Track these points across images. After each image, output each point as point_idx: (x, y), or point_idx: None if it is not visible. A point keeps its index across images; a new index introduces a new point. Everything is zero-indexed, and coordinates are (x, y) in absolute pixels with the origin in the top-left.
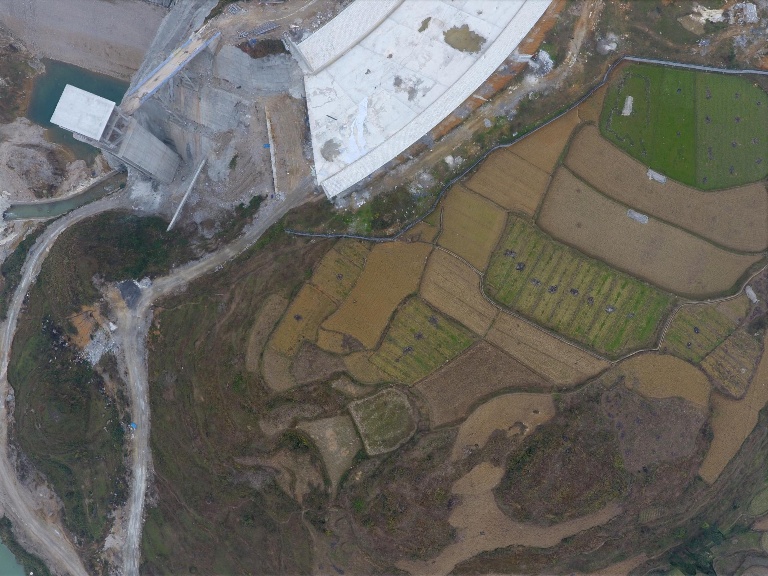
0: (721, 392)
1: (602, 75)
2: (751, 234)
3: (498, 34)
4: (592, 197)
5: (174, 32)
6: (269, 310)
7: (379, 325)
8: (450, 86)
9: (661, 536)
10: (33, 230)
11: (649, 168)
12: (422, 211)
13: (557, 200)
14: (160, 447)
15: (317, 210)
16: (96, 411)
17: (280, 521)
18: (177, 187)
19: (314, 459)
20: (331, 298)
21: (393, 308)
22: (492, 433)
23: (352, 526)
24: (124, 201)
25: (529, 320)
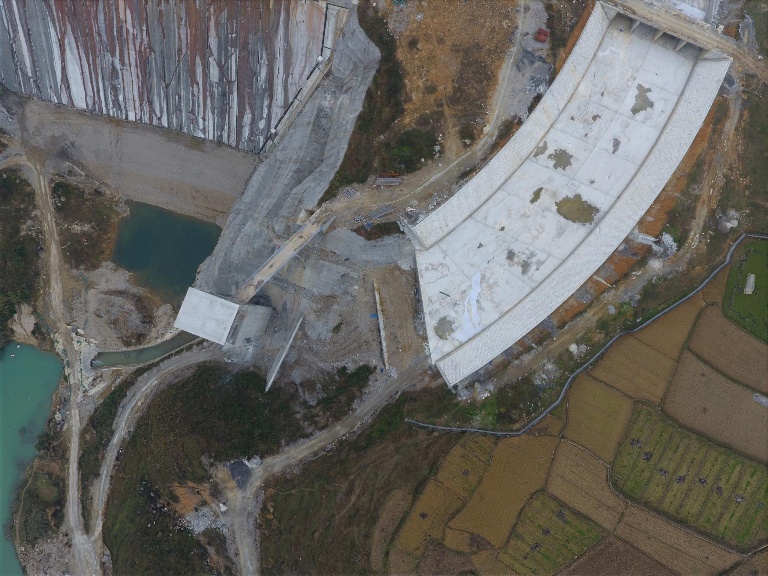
0: None
1: (724, 254)
2: None
3: (611, 204)
4: (717, 381)
5: (276, 197)
6: (393, 506)
7: (507, 523)
8: (564, 259)
9: None
10: (122, 379)
11: None
12: (548, 403)
13: (682, 385)
14: None
15: (438, 399)
16: None
17: None
18: (270, 338)
19: None
20: (457, 495)
21: (521, 505)
22: None
23: None
24: (216, 353)
25: (658, 513)
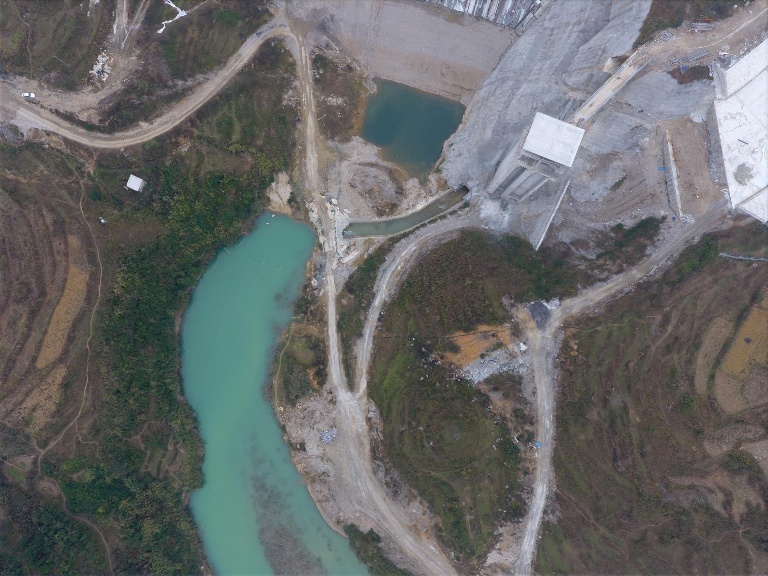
0: None
1: None
2: None
3: None
4: None
5: (561, 56)
6: (715, 333)
7: None
8: None
9: None
10: (375, 248)
11: None
12: None
13: None
14: (569, 466)
15: (753, 234)
16: (485, 429)
17: (710, 540)
18: (526, 206)
19: (756, 479)
20: None
21: None
22: None
23: None
24: (474, 220)
25: None
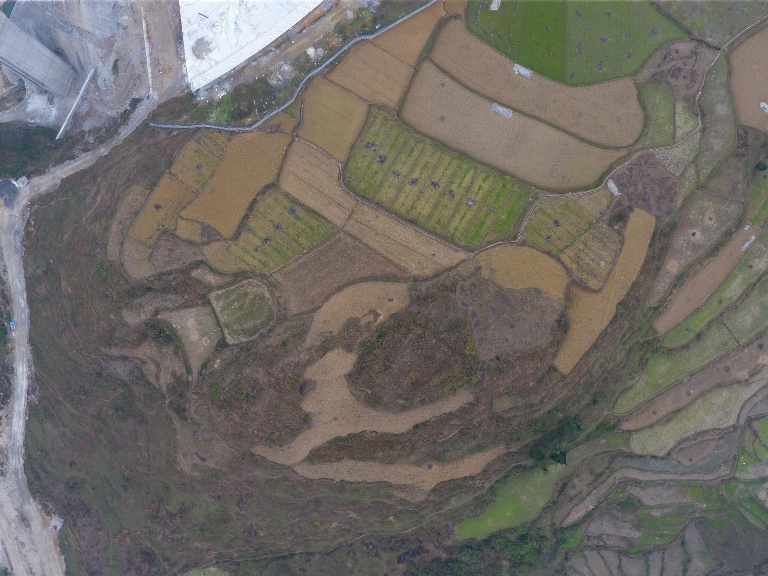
0: (579, 284)
1: None
2: (617, 129)
3: None
4: (456, 91)
5: None
6: (131, 200)
7: (237, 214)
8: None
9: (518, 428)
10: None
11: (515, 62)
12: (282, 102)
13: (421, 94)
14: (38, 343)
15: (181, 103)
16: None
17: (147, 412)
18: (72, 100)
19: (176, 348)
20: (190, 188)
21: (251, 198)
22: (346, 321)
23: (210, 412)
24: (20, 114)
25: (388, 211)
